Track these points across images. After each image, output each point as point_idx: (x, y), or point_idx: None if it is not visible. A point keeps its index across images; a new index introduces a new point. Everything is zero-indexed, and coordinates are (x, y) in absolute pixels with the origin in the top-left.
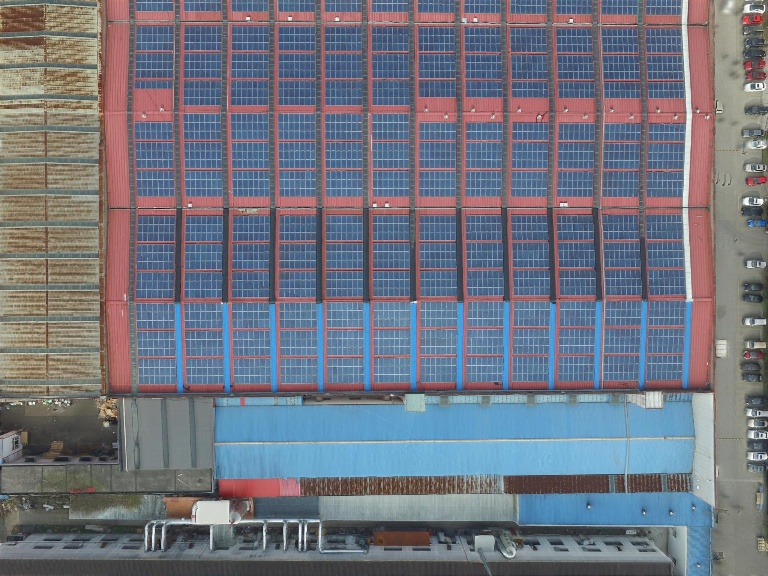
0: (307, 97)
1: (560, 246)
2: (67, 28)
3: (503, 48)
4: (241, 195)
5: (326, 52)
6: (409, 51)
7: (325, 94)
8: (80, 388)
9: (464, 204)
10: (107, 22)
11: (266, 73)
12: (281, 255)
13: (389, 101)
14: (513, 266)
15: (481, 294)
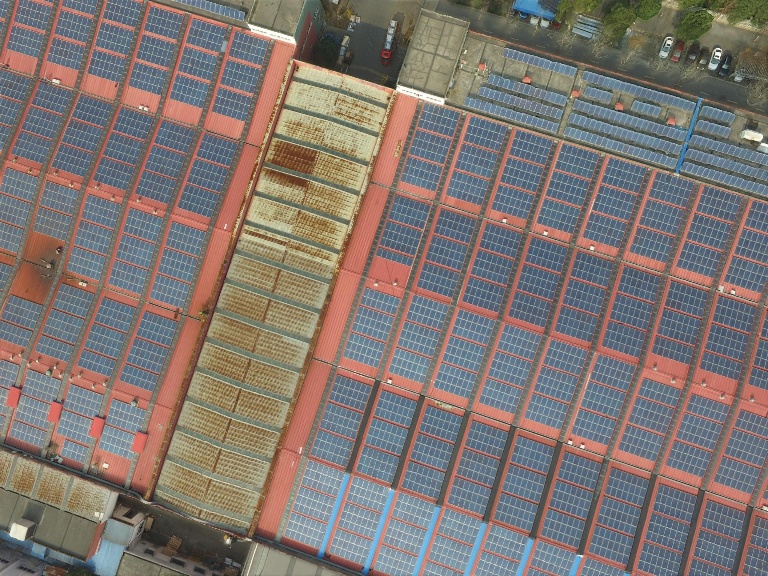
0: (539, 317)
1: (750, 550)
2: (331, 178)
3: (753, 329)
4: (442, 388)
5: (571, 277)
6: (655, 302)
7: (557, 319)
8: (229, 521)
9: (661, 472)
10: (369, 182)
11: (506, 280)
12: (462, 461)
13: (620, 347)
14: (694, 554)
15: (652, 572)
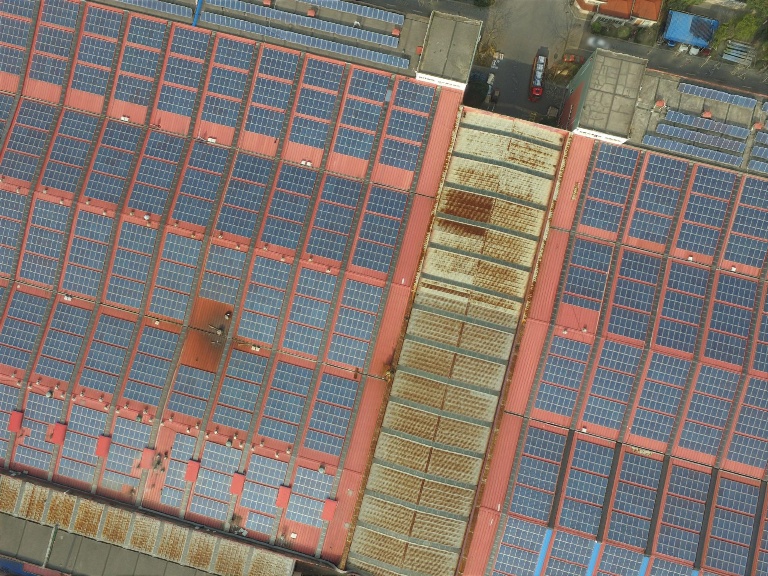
0: (736, 355)
1: None
2: (509, 225)
3: None
4: (639, 434)
5: (763, 312)
6: None
7: (754, 356)
8: None
9: None
10: None
11: (698, 319)
12: (666, 507)
13: None
14: None
15: None
